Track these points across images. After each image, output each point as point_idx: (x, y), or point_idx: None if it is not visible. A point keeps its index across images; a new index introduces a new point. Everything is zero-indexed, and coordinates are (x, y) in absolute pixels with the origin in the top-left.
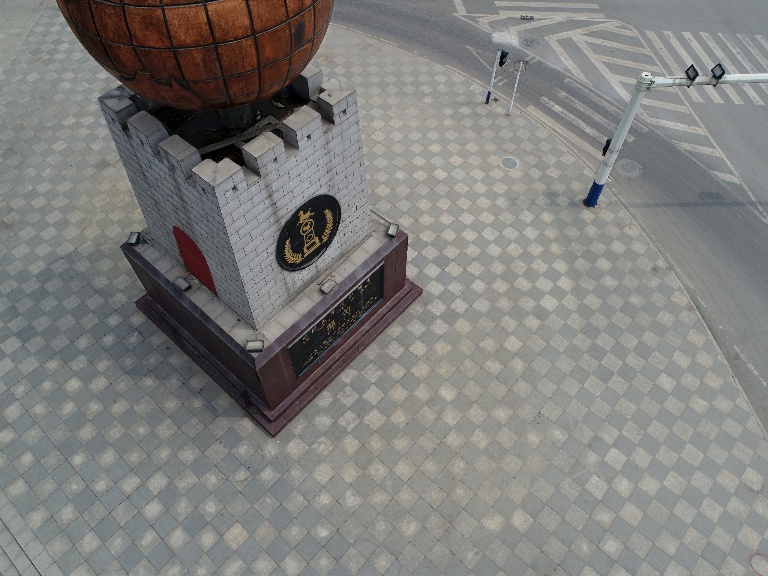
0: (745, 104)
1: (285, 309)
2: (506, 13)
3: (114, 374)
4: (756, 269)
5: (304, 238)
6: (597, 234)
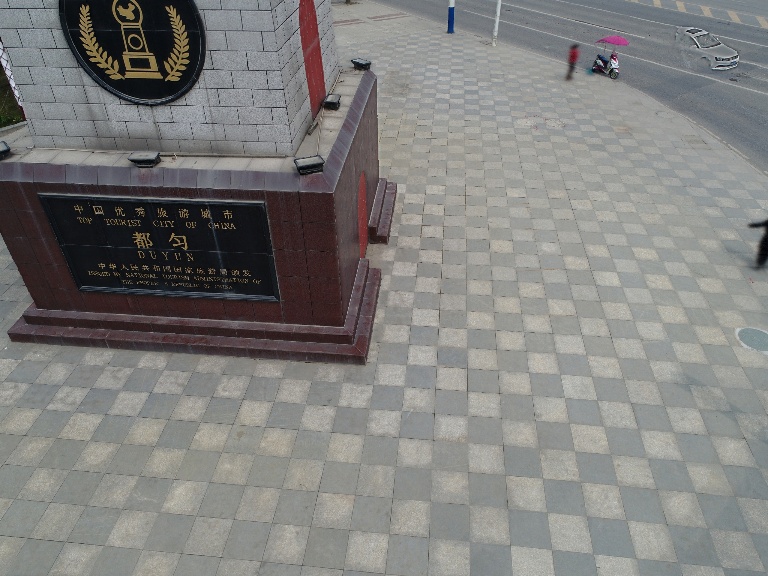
0: None
1: (85, 150)
2: None
3: None
4: None
5: (123, 33)
6: None
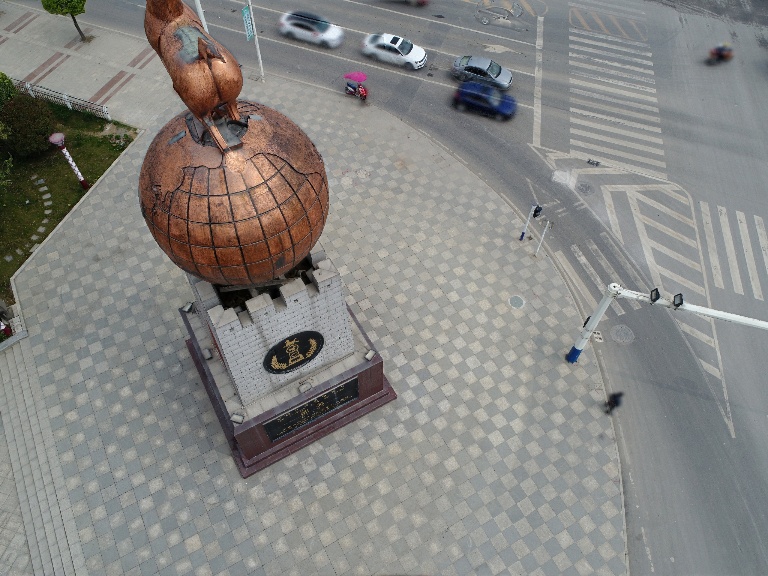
0: (764, 301)
1: (269, 396)
2: (576, 153)
3: (154, 392)
4: (696, 464)
5: (289, 355)
6: (565, 389)
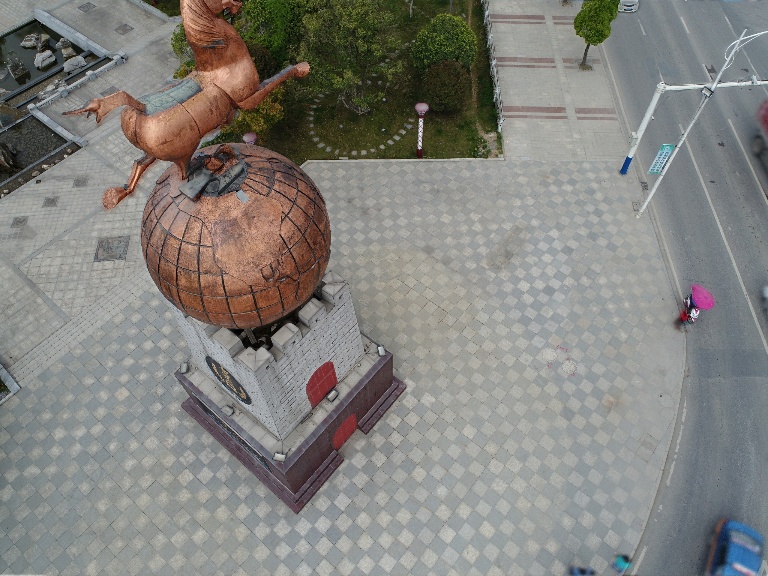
0: None
1: (213, 384)
2: None
3: None
4: None
5: None
6: None
